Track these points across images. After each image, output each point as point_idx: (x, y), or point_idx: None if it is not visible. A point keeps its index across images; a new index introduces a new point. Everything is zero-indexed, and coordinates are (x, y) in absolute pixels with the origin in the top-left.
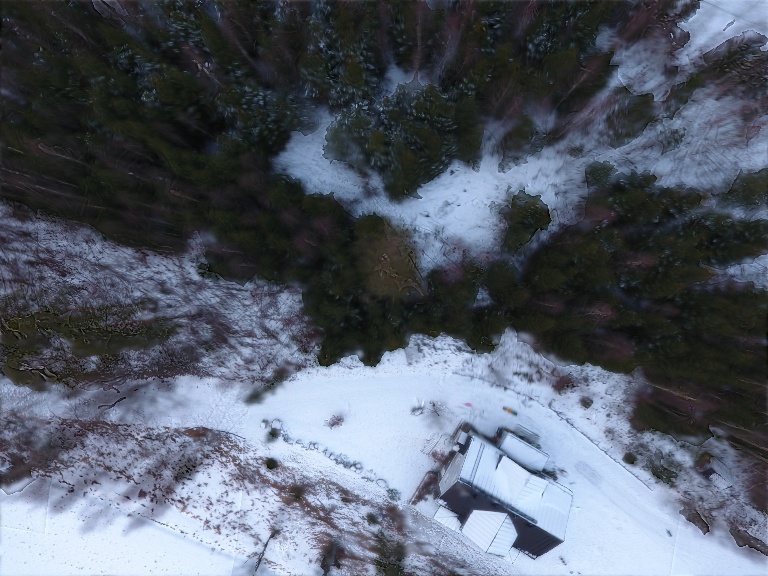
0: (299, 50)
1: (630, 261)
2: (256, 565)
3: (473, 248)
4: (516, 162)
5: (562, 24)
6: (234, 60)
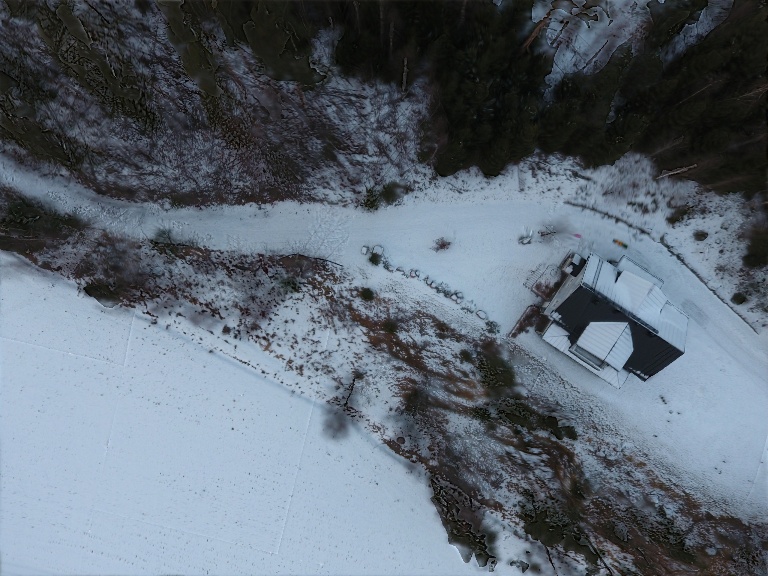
0: None
1: None
2: (350, 389)
3: (605, 59)
4: None
5: None
6: None
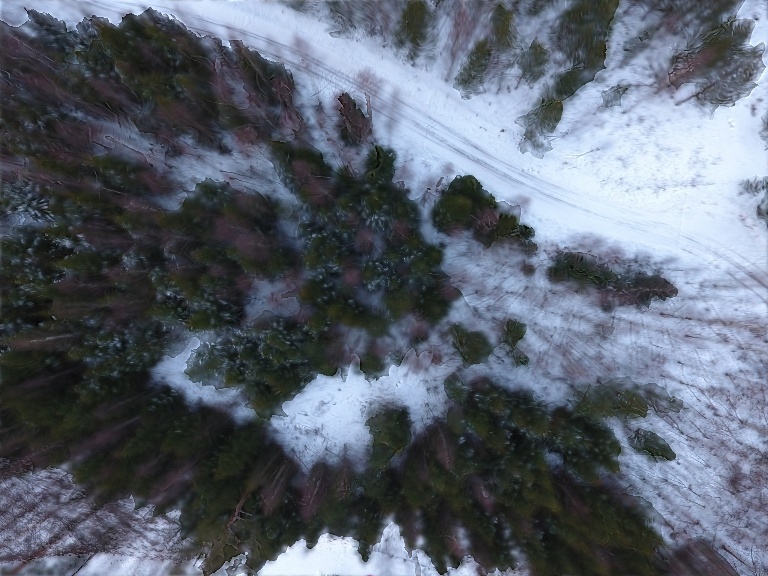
0: (150, 294)
1: (488, 477)
2: None
3: (353, 442)
4: None
5: (400, 261)
6: (84, 314)
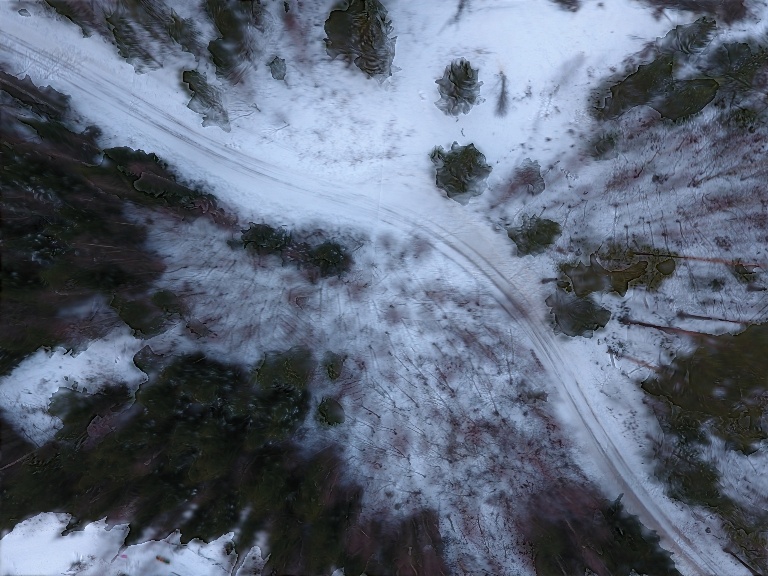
0: None
1: None
2: None
3: None
4: (75, 350)
5: None
6: None
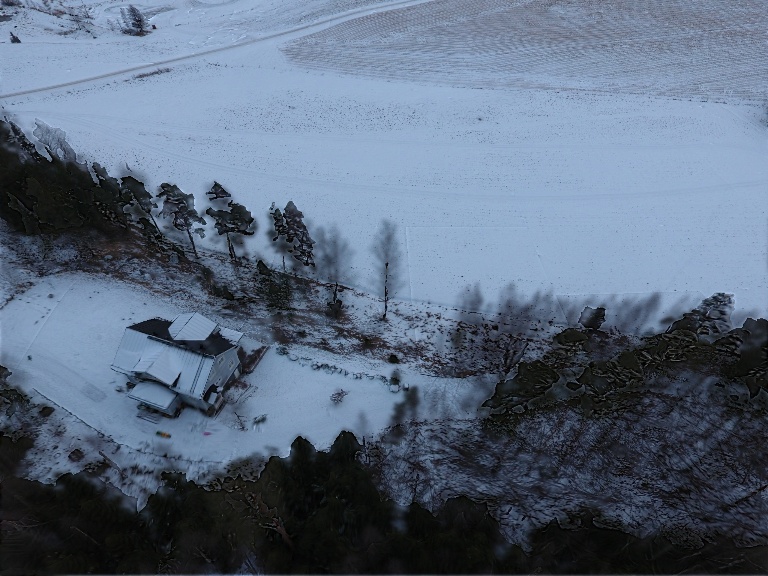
0: None
1: None
2: (387, 291)
3: None
4: None
5: None
6: None
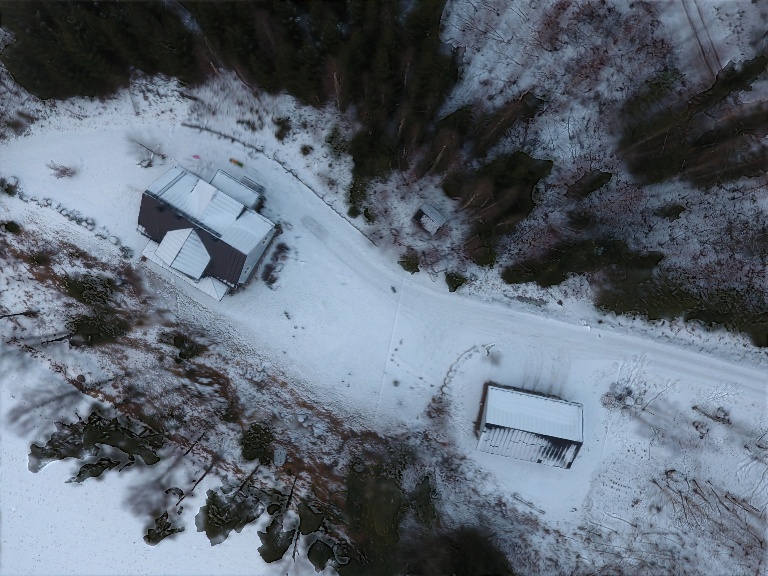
0: None
1: None
2: None
3: None
4: None
5: None
6: None
